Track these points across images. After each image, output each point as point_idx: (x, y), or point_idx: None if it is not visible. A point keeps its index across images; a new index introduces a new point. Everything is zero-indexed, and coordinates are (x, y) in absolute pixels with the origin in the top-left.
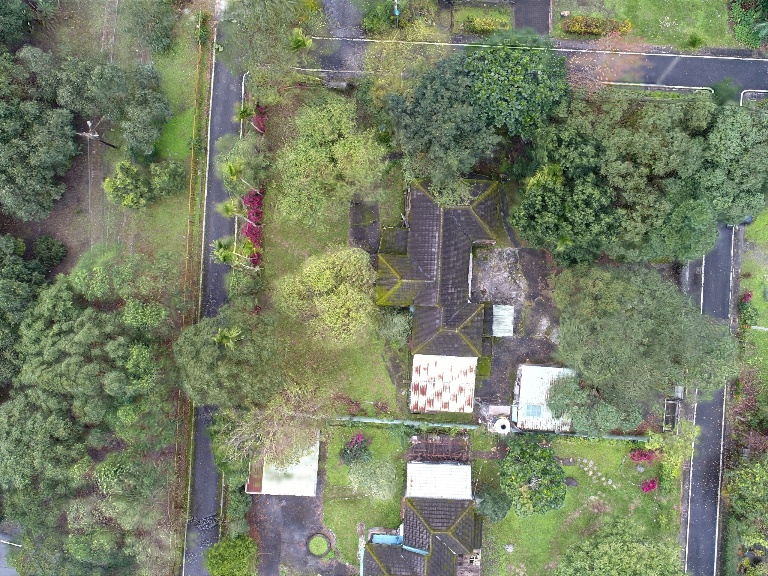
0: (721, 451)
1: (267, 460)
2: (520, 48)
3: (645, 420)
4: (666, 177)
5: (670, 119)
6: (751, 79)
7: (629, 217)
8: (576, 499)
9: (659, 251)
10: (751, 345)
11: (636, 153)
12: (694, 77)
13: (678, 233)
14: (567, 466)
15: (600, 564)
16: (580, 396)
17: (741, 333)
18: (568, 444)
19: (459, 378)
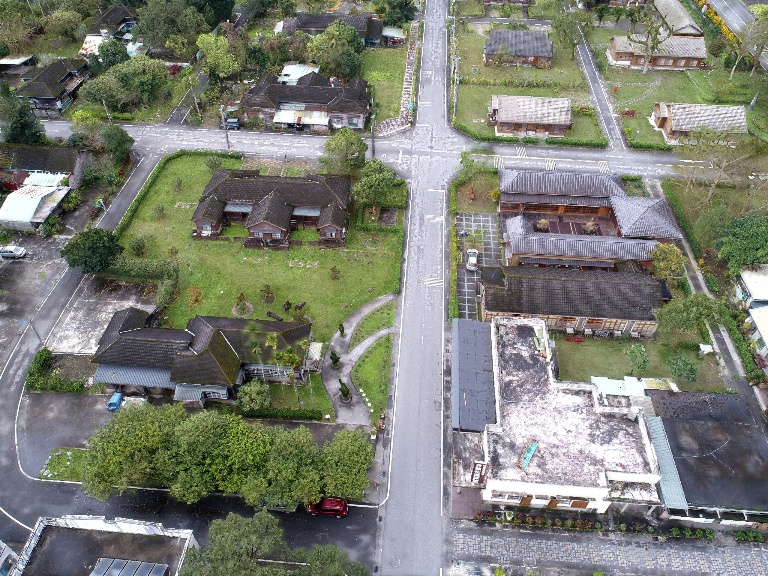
0: None
1: (5, 58)
2: None
3: None
4: None
5: None
6: None
7: None
8: None
9: None
10: None
11: None
12: None
13: None
14: None
15: None
16: None
17: None
18: None
19: None
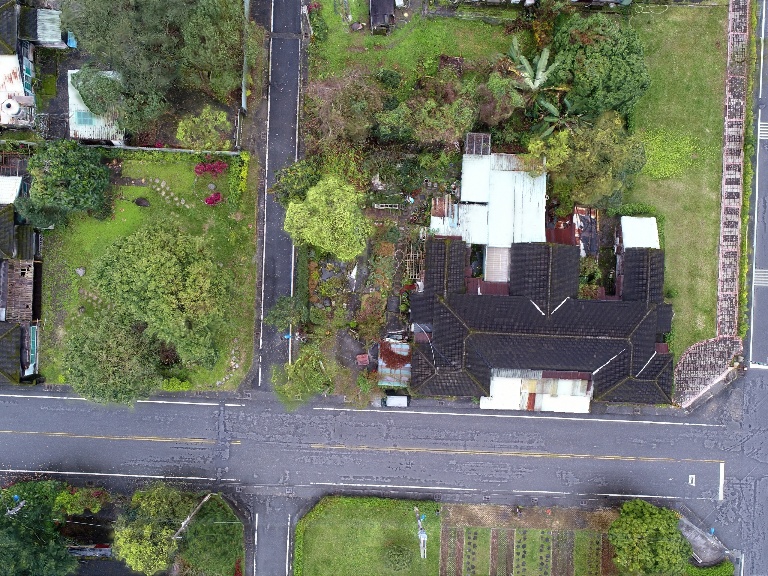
0: None
1: None
2: None
3: None
4: None
5: None
6: None
7: None
8: None
9: None
10: (323, 60)
11: None
12: None
13: None
14: (139, 187)
15: (124, 253)
16: (85, 71)
17: None
18: (140, 164)
19: (6, 85)
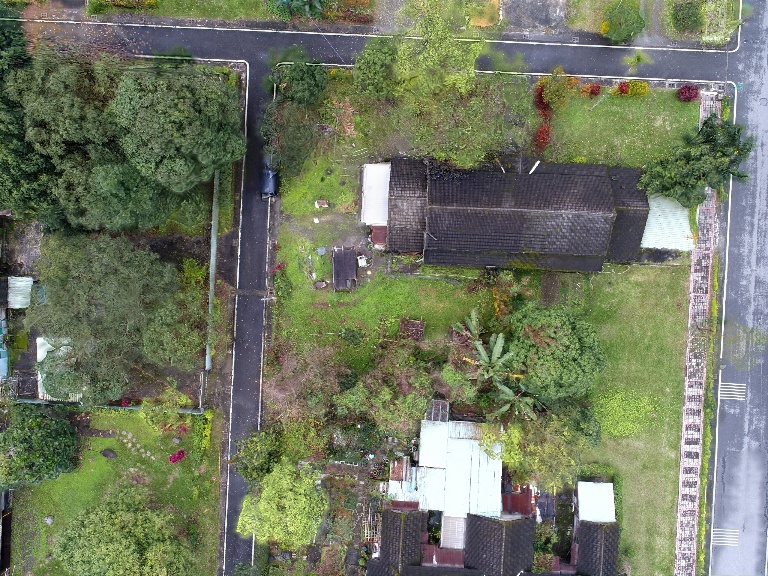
0: (258, 422)
1: None
2: (56, 22)
3: (181, 392)
4: (85, 143)
5: (63, 84)
6: (285, 52)
7: (53, 184)
8: (116, 471)
9: (98, 218)
10: (287, 316)
11: (44, 119)
12: (229, 50)
13: (105, 199)
14: (106, 438)
15: (86, 532)
16: (49, 364)
17: (278, 305)
18: (107, 416)
19: None
